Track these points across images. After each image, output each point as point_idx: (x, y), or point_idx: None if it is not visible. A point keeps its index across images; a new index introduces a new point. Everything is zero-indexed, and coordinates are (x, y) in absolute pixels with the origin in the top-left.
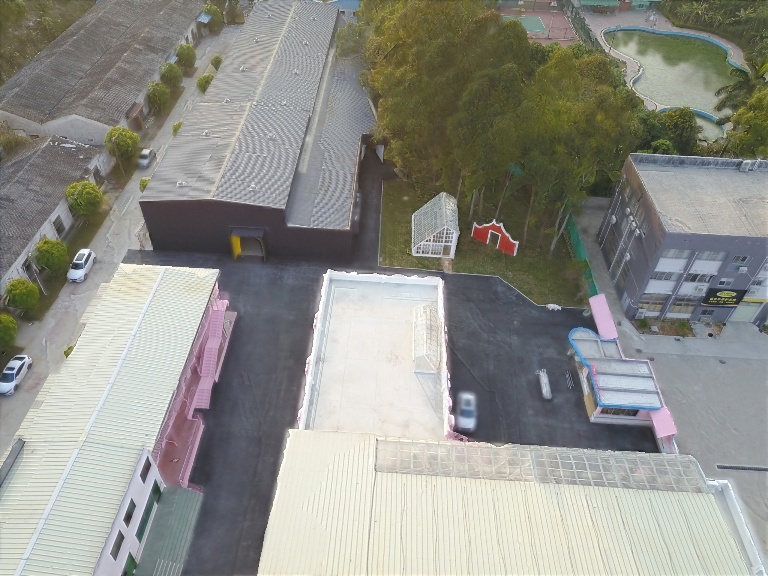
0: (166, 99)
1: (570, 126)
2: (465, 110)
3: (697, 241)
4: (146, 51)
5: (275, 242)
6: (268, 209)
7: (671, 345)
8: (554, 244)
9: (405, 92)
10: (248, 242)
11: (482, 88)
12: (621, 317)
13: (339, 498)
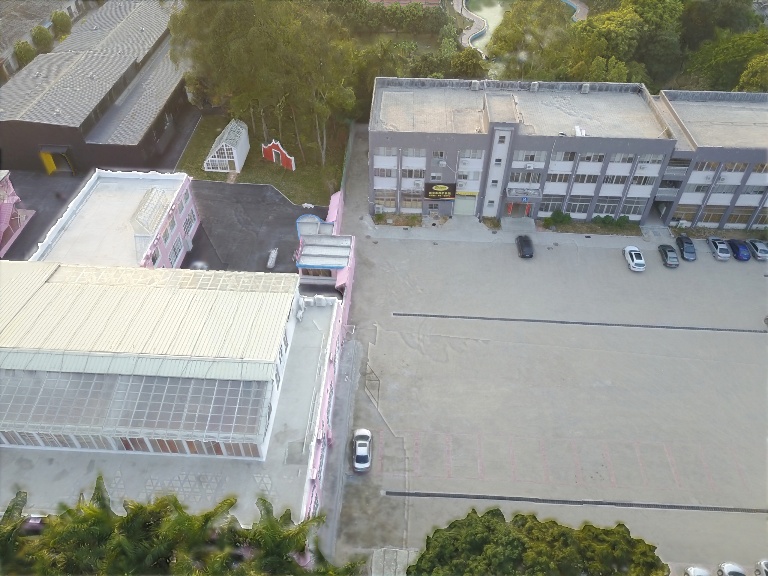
0: (31, 56)
1: (286, 46)
2: (211, 38)
3: (396, 139)
4: (21, 17)
5: (80, 158)
6: (65, 127)
7: (398, 232)
8: (324, 159)
9: (180, 29)
10: (61, 160)
11: (219, 18)
12: (365, 213)
13: (7, 296)
